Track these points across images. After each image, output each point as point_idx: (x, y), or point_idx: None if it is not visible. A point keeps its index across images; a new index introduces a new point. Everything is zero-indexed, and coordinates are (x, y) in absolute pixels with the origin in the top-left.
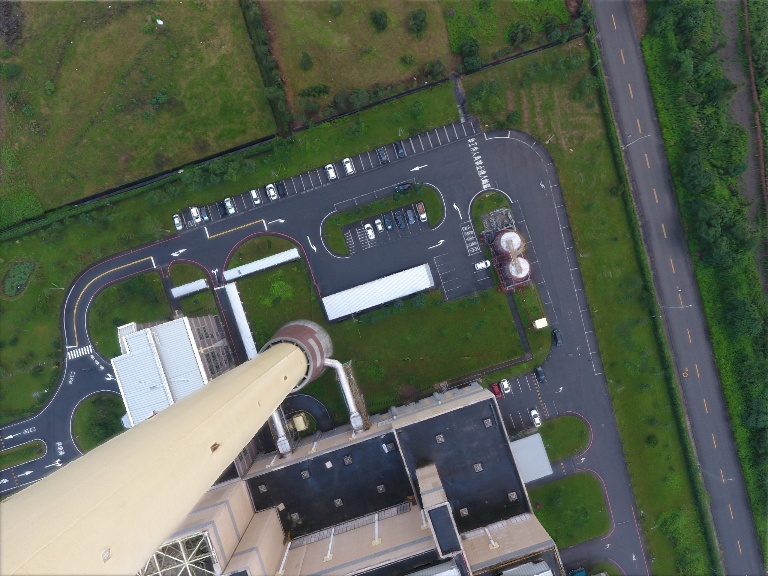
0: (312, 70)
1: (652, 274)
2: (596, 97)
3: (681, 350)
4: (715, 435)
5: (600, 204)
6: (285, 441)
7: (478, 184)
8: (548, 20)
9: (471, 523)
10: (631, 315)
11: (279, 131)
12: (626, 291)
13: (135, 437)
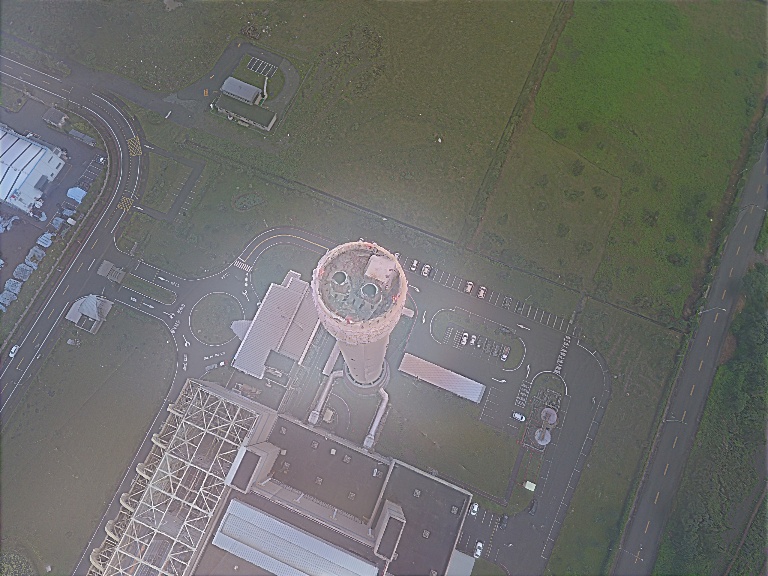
0: (503, 226)
1: (629, 520)
2: (667, 375)
3: None
4: None
5: (624, 443)
6: (317, 415)
7: (553, 366)
8: (666, 308)
9: (393, 568)
10: (595, 535)
11: (457, 242)
12: None
13: None
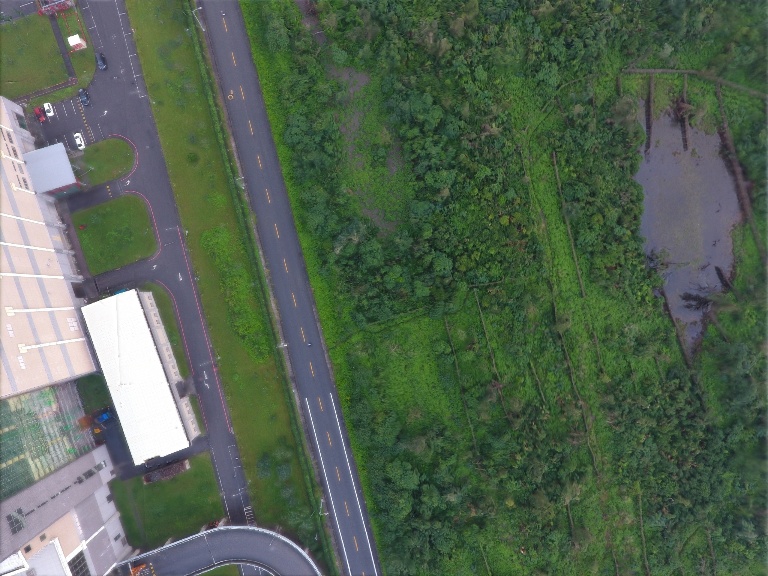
0: None
1: None
2: None
3: (226, 73)
4: (260, 156)
5: None
6: None
7: None
8: None
9: None
10: (172, 37)
11: None
12: (167, 13)
13: None
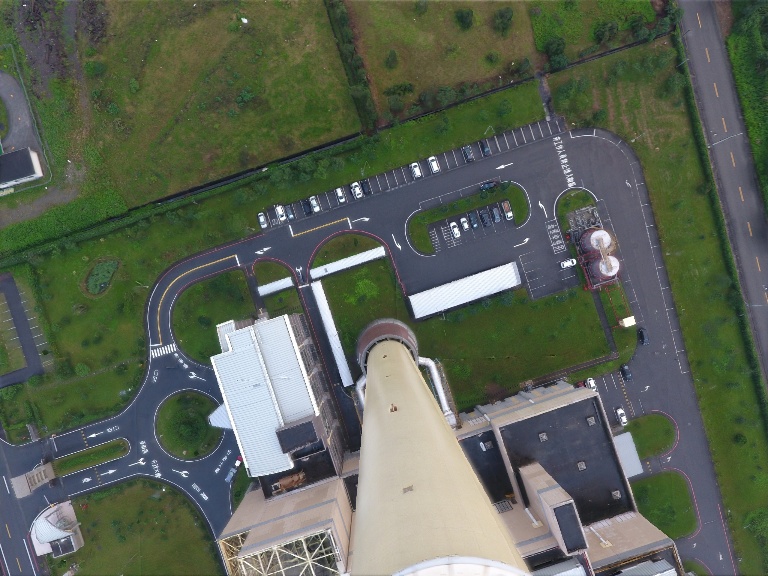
0: (397, 68)
1: (738, 273)
2: (682, 95)
3: (767, 349)
4: None
5: (686, 202)
6: None
7: (563, 182)
8: (634, 19)
9: None
10: (718, 314)
11: (364, 129)
12: (713, 290)
13: (420, 428)
